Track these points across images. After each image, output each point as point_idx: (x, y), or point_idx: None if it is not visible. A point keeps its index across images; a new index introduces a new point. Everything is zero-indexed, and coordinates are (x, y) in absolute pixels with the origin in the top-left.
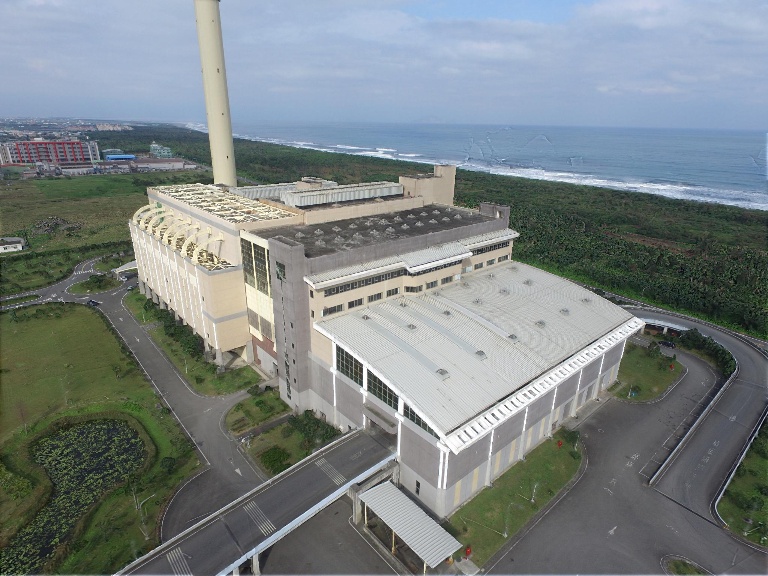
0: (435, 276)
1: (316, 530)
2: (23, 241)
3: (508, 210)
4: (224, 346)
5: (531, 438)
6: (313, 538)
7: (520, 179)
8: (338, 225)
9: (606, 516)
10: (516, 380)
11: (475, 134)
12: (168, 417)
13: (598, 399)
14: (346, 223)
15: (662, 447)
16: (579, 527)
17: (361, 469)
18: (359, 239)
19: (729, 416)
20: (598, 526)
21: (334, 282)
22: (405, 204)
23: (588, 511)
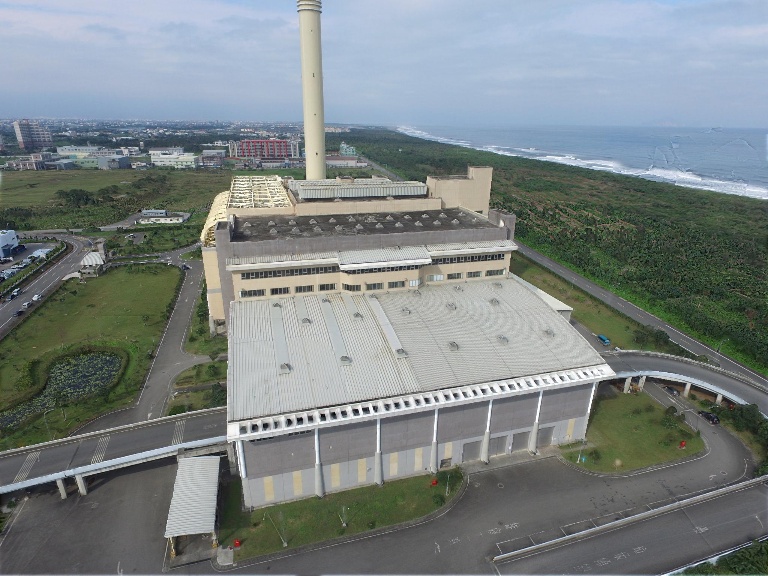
0: (379, 278)
1: (152, 478)
2: (188, 216)
3: (512, 219)
4: (216, 314)
5: (398, 465)
6: (143, 483)
7: (710, 193)
8: (324, 219)
9: (405, 570)
10: (359, 393)
11: (658, 138)
12: (147, 362)
13: (535, 452)
14: (335, 218)
15: (559, 528)
16: (364, 568)
17: (201, 438)
18: (316, 232)
19: (697, 525)
20: (385, 575)
21: (248, 267)
22: (417, 205)
23: (391, 558)
